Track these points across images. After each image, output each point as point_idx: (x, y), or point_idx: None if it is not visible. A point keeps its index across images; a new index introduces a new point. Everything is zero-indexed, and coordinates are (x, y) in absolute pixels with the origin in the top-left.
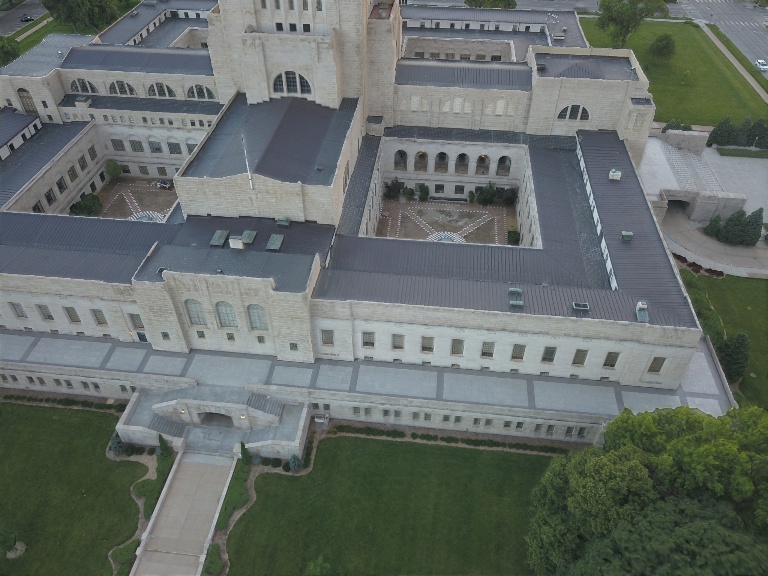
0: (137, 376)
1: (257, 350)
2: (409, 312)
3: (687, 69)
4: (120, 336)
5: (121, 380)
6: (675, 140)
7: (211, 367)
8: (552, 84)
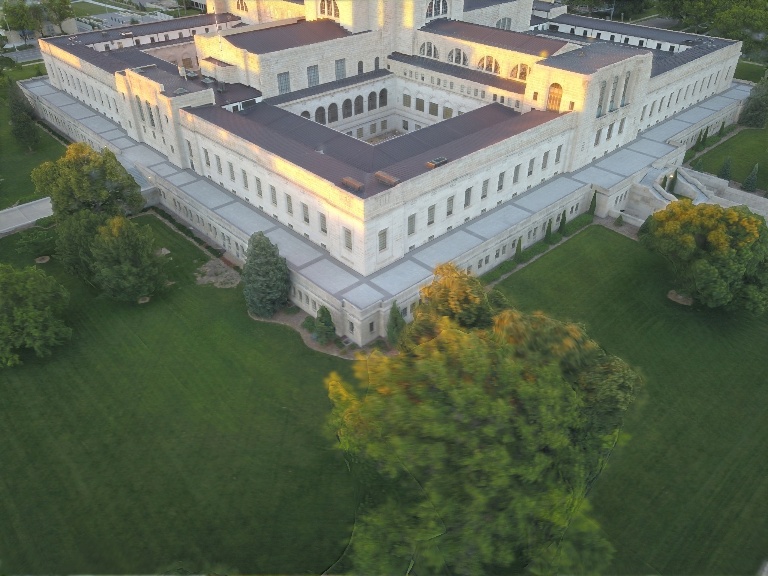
0: None
1: None
2: None
3: None
4: None
5: None
6: None
7: None
8: None
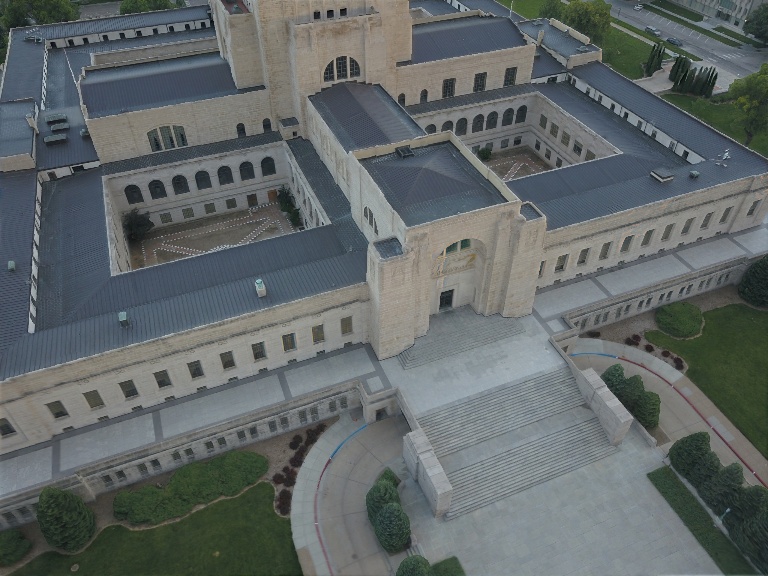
0: None
1: None
2: None
3: None
4: None
5: None
6: (584, 388)
7: None
8: None
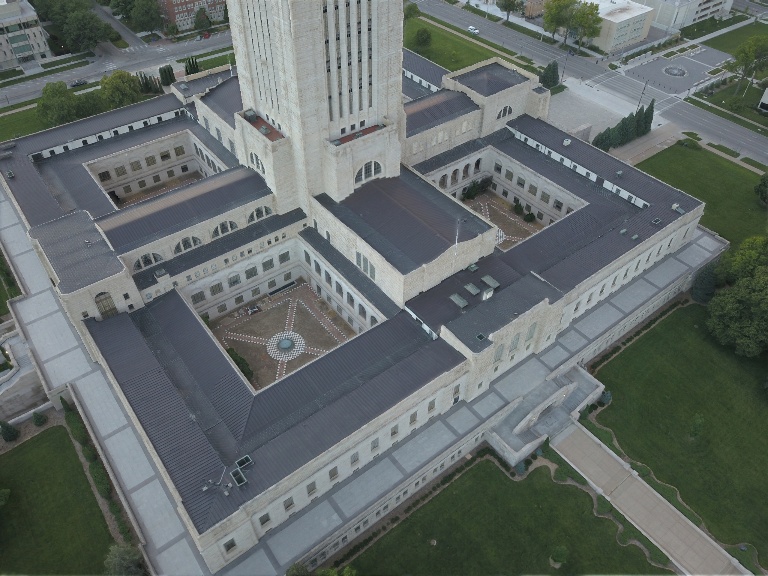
0: (491, 421)
1: (523, 357)
2: (602, 273)
3: (442, 49)
4: (443, 410)
5: (479, 433)
6: None
7: (512, 385)
8: (494, 99)
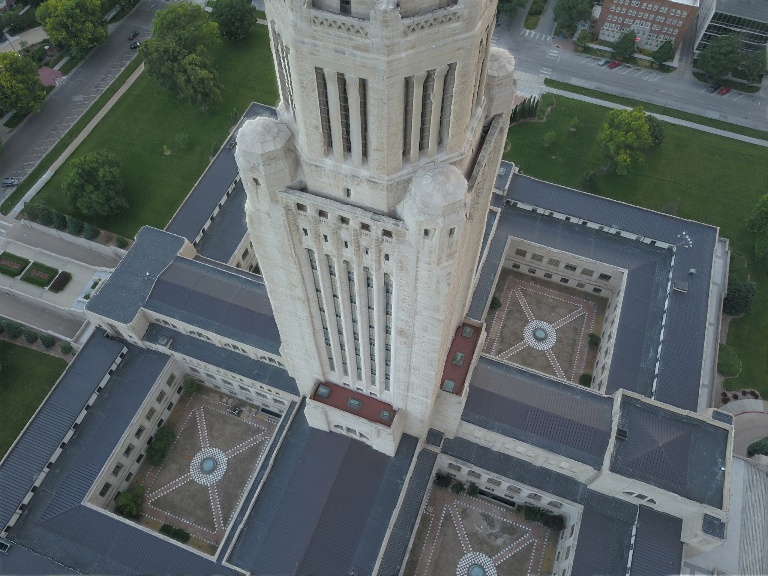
0: None
1: None
2: None
3: None
4: None
5: None
6: (765, 468)
7: None
8: (622, 481)
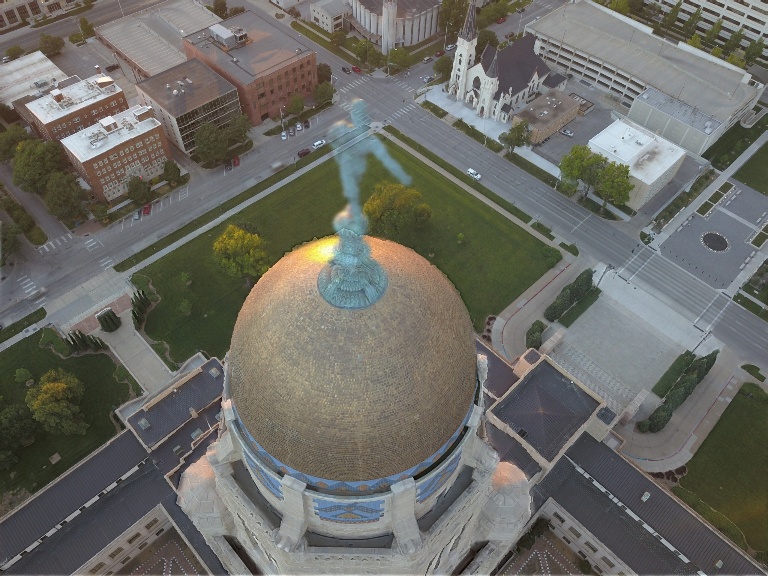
0: None
1: None
2: None
3: (443, 218)
4: None
5: None
6: None
7: None
8: None
